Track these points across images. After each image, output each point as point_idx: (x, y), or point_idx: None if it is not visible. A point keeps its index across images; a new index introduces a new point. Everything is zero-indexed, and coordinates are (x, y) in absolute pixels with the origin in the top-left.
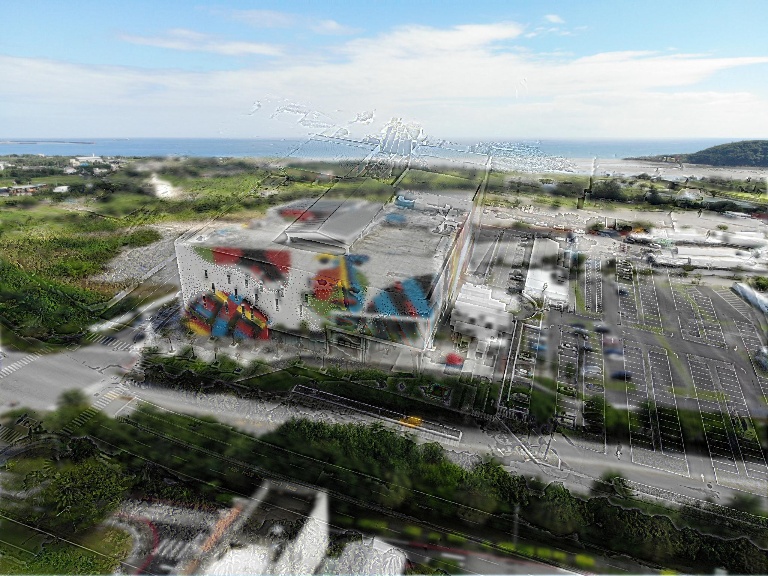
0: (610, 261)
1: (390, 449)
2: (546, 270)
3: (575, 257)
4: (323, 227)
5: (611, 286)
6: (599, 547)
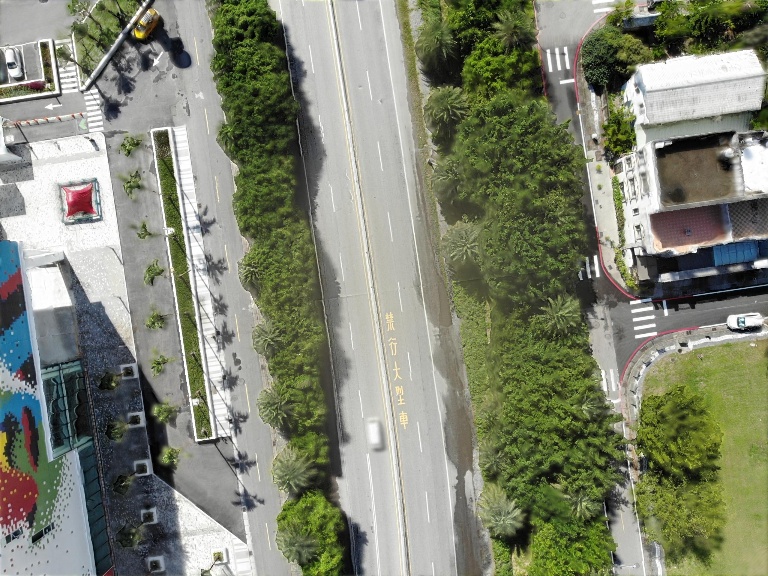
0: None
1: (279, 198)
2: None
3: None
4: None
5: None
6: None
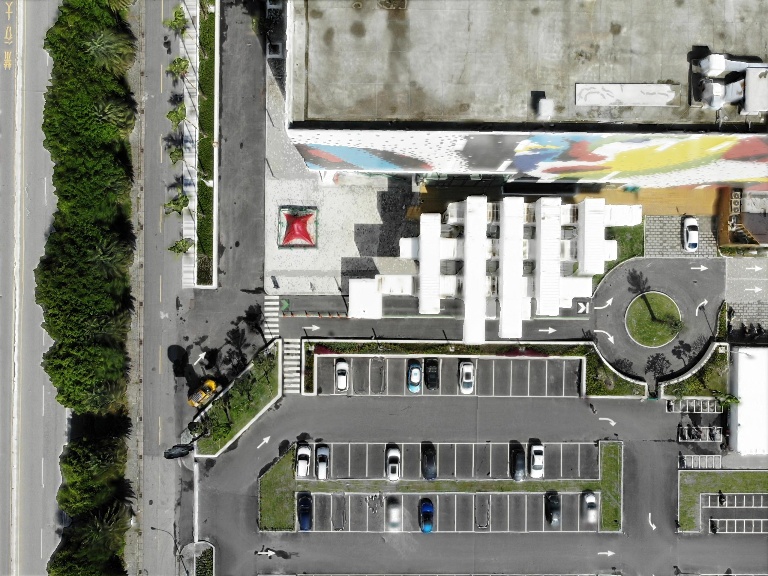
0: None
1: None
2: None
3: None
4: None
5: None
6: (66, 518)
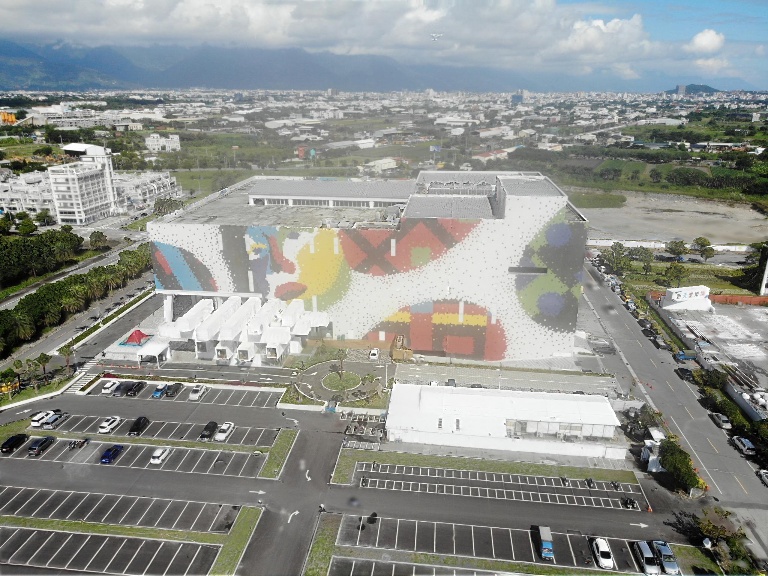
0: (650, 527)
1: None
2: (461, 399)
3: (605, 464)
4: (269, 180)
5: (500, 514)
6: None
